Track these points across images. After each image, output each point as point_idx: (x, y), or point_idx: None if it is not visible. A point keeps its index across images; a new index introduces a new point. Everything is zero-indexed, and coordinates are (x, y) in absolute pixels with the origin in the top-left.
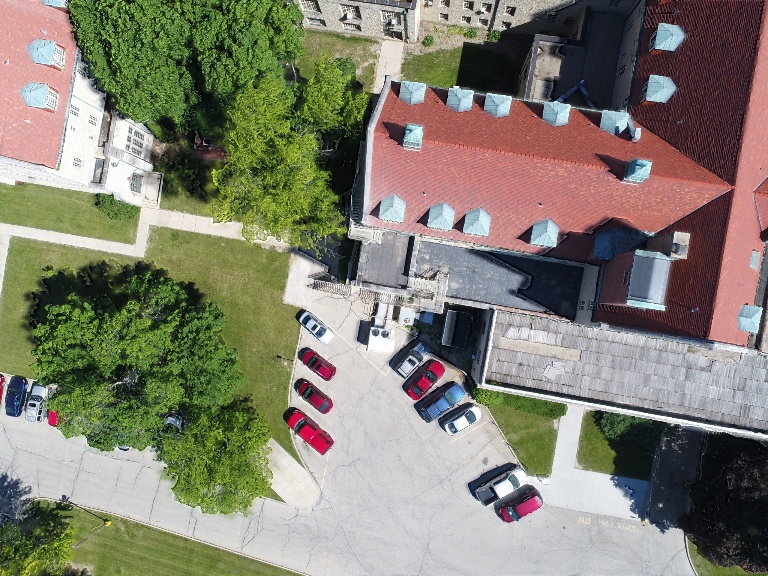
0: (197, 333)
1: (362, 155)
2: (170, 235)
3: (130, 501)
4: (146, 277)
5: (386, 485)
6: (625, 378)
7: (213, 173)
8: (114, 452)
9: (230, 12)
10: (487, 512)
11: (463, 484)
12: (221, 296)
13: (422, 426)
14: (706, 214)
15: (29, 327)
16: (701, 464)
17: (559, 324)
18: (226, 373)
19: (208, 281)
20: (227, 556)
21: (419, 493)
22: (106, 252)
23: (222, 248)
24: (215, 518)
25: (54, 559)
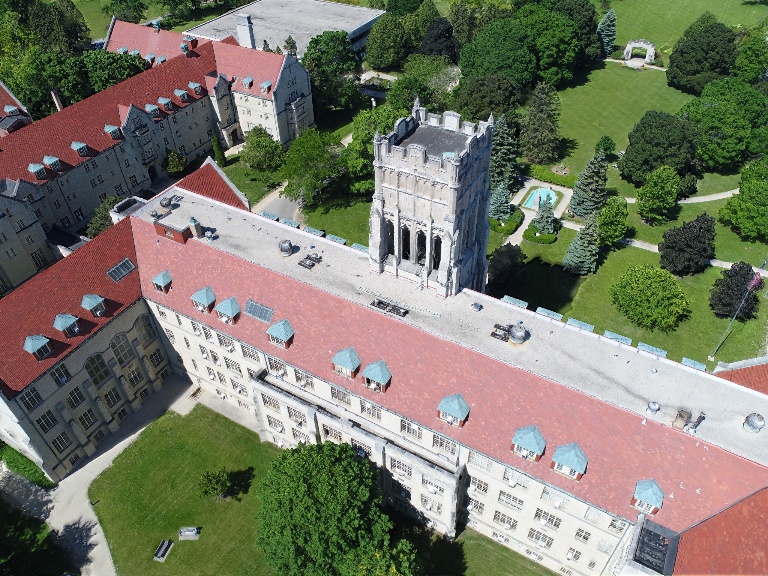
0: None
1: None
2: None
3: None
4: None
5: None
6: None
7: None
8: None
9: None
10: None
11: None
12: None
13: None
14: None
15: None
16: None
17: None
18: None
19: None
20: None
21: None
22: None
23: None
24: None
25: None
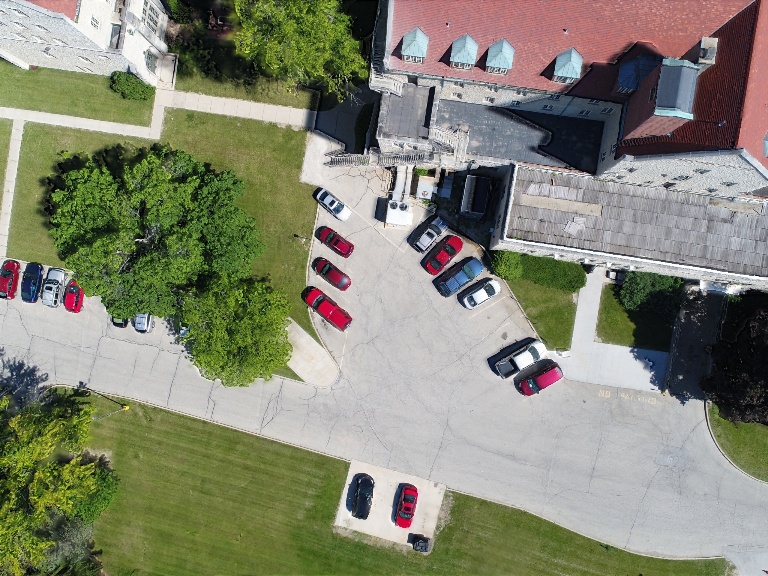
0: (217, 194)
1: None
2: (185, 116)
3: (148, 385)
4: (163, 151)
5: (405, 362)
6: (647, 232)
7: (236, 0)
8: (131, 336)
9: None
10: (507, 387)
11: (482, 359)
12: (237, 176)
13: (441, 302)
14: (732, 28)
15: (44, 212)
16: (721, 332)
17: (580, 179)
18: (245, 238)
19: (224, 161)
20: (246, 438)
21: (438, 369)
22: (121, 135)
23: (238, 128)
24: (234, 400)
25: (73, 437)
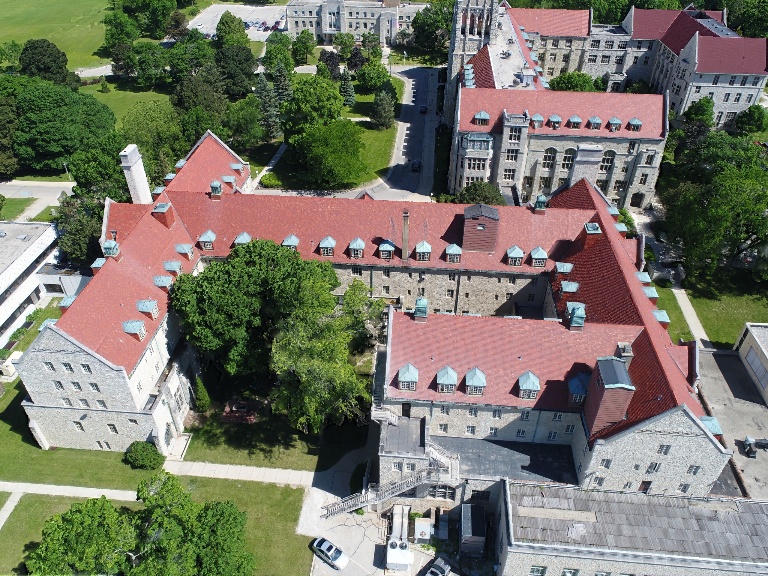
0: None
1: (379, 354)
2: (189, 481)
3: None
4: None
5: None
6: (645, 533)
7: (274, 341)
8: None
9: (294, 263)
10: None
11: None
12: None
13: None
14: (636, 347)
15: None
16: None
17: (566, 491)
18: (243, 567)
19: None
20: None
21: None
22: (120, 500)
23: (238, 489)
24: None
25: None
